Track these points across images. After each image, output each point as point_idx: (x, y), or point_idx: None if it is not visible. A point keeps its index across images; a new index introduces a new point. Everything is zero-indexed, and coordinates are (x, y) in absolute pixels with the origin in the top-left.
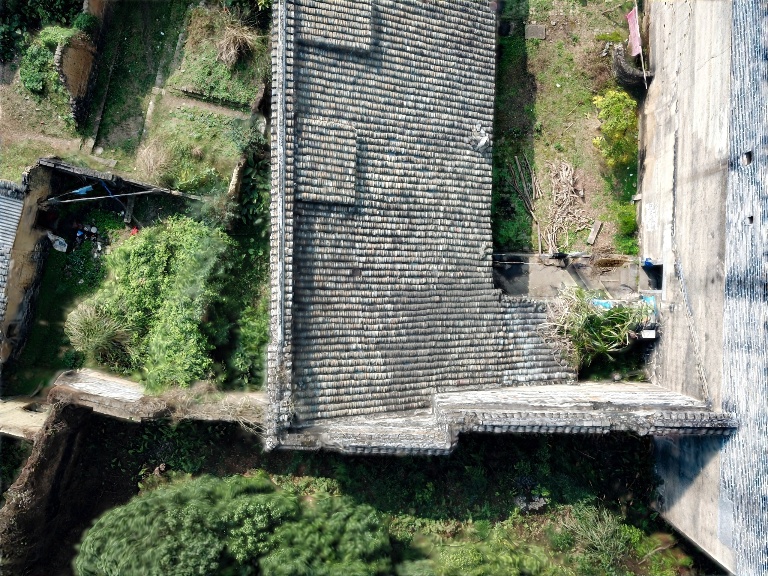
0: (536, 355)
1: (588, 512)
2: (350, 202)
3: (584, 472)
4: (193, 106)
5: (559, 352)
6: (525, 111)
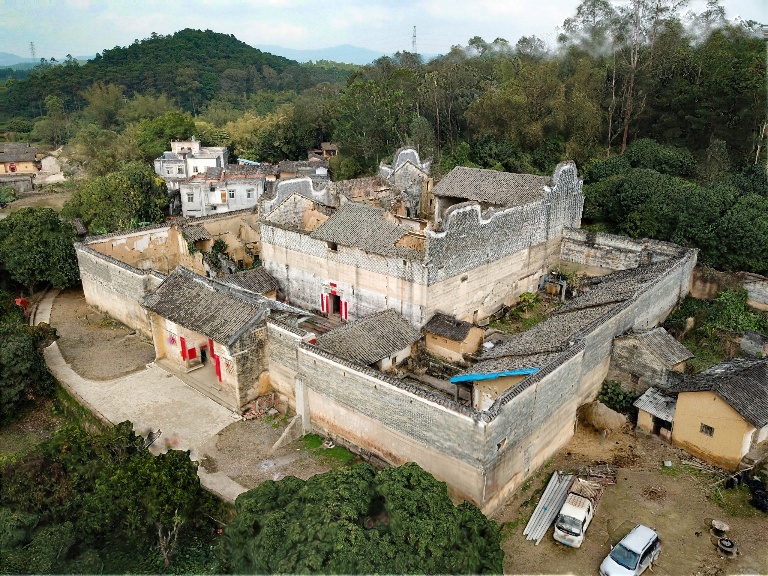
0: None
1: None
2: None
3: None
4: None
5: None
6: None
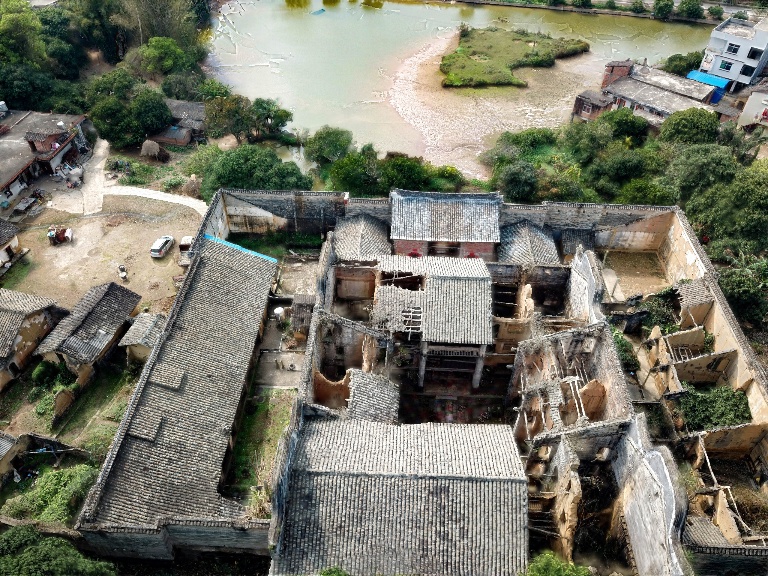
0: None
1: None
2: (152, 440)
3: None
4: (109, 424)
5: None
6: (264, 432)
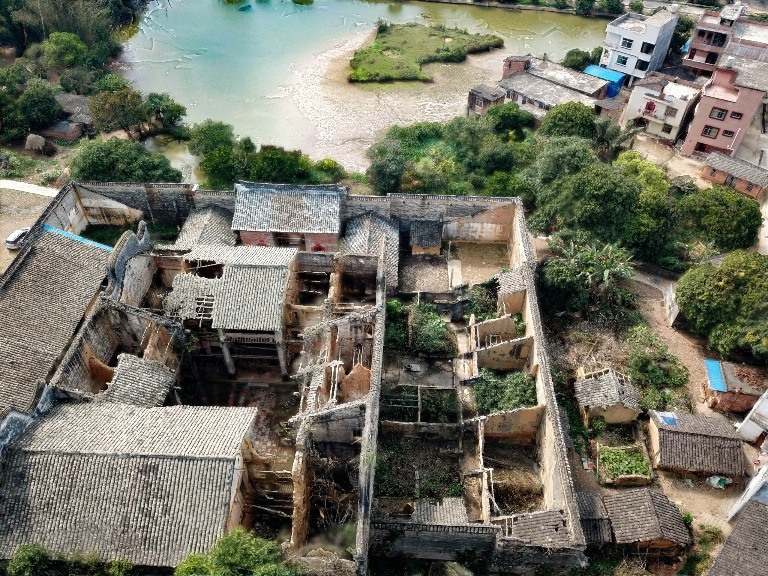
0: None
1: None
2: None
3: None
4: None
5: None
6: None
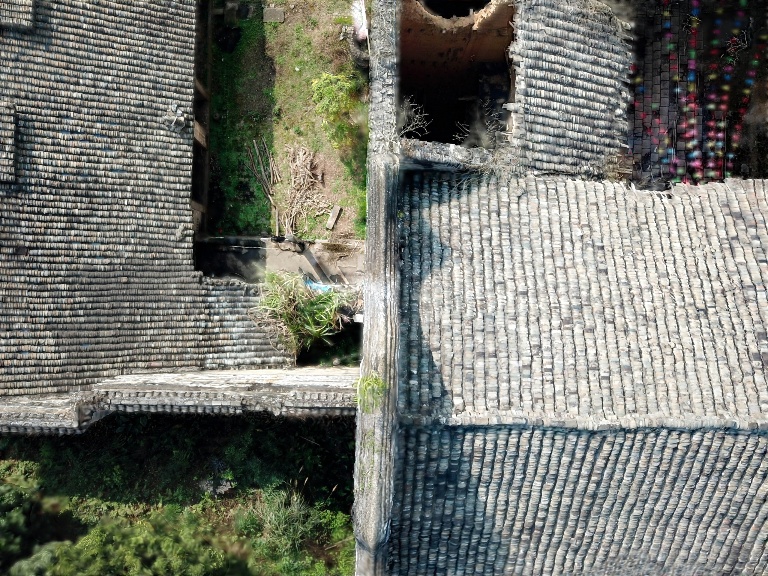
0: (248, 339)
1: (275, 497)
2: (8, 179)
3: (300, 458)
4: None
5: (276, 336)
6: (264, 95)
